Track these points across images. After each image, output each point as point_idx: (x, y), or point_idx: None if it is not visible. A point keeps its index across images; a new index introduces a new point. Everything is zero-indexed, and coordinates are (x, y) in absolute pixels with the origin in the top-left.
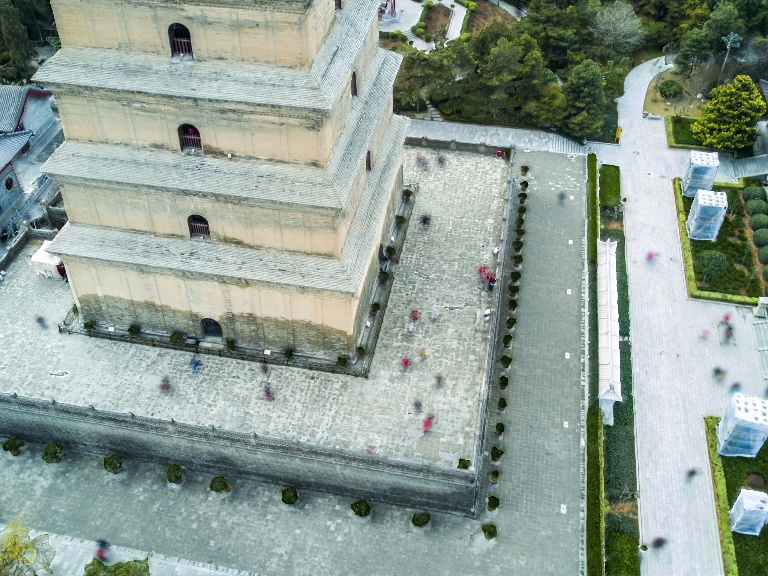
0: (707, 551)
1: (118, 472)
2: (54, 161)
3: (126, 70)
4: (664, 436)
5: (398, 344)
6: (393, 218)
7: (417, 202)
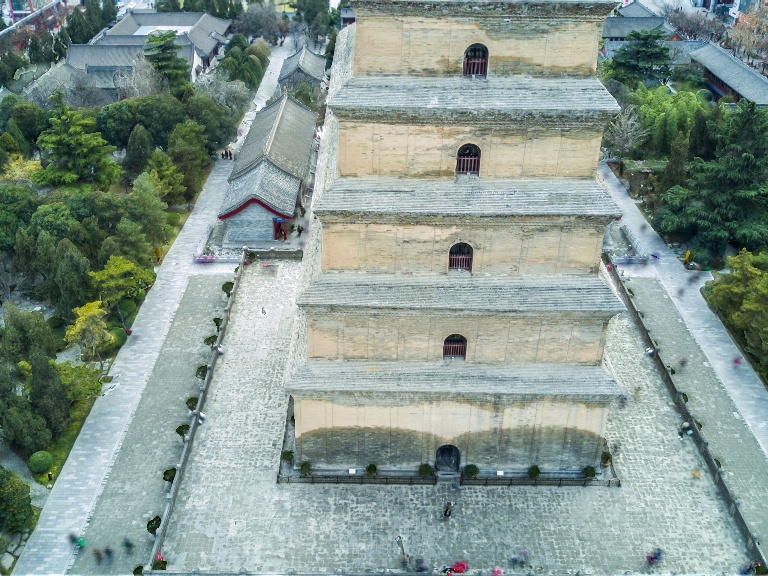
0: None
1: (198, 376)
2: None
3: None
4: None
5: (331, 501)
6: (528, 462)
7: (587, 488)
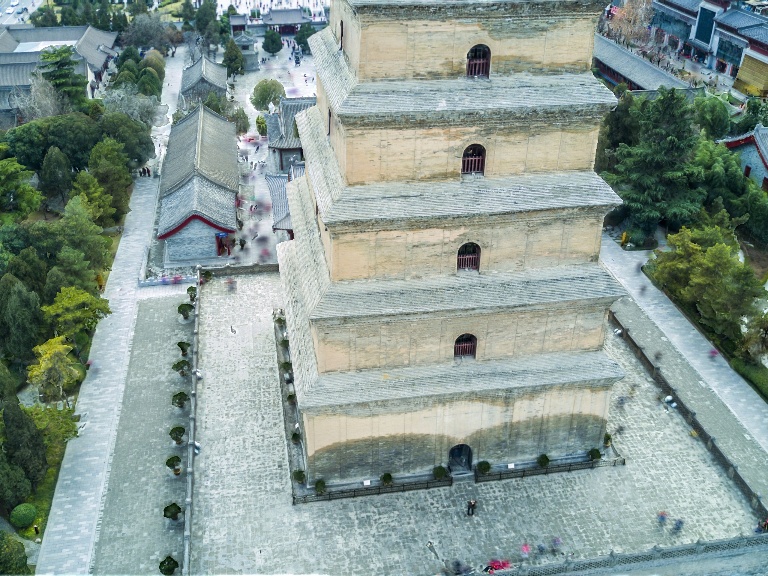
0: None
1: (175, 405)
2: None
3: None
4: None
5: (353, 516)
6: (536, 452)
7: (595, 470)
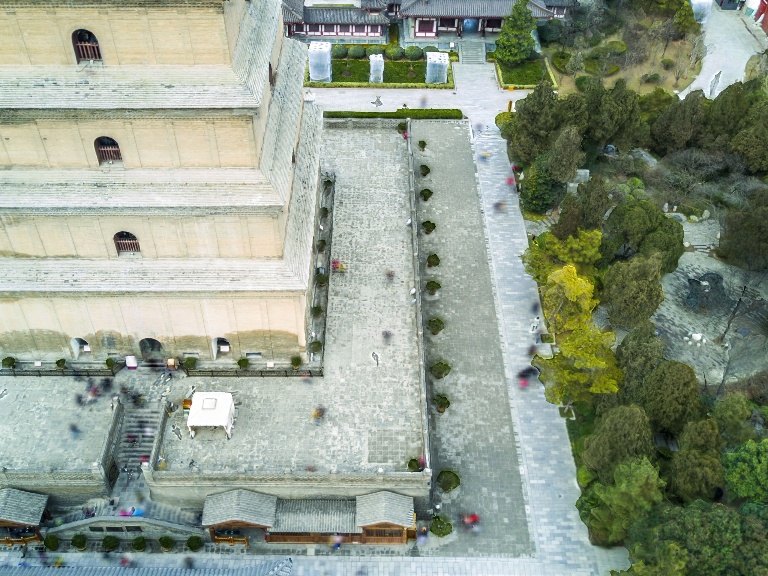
0: (395, 93)
1: None
2: (277, 188)
3: (256, 41)
4: (319, 102)
5: None
6: None
7: None
